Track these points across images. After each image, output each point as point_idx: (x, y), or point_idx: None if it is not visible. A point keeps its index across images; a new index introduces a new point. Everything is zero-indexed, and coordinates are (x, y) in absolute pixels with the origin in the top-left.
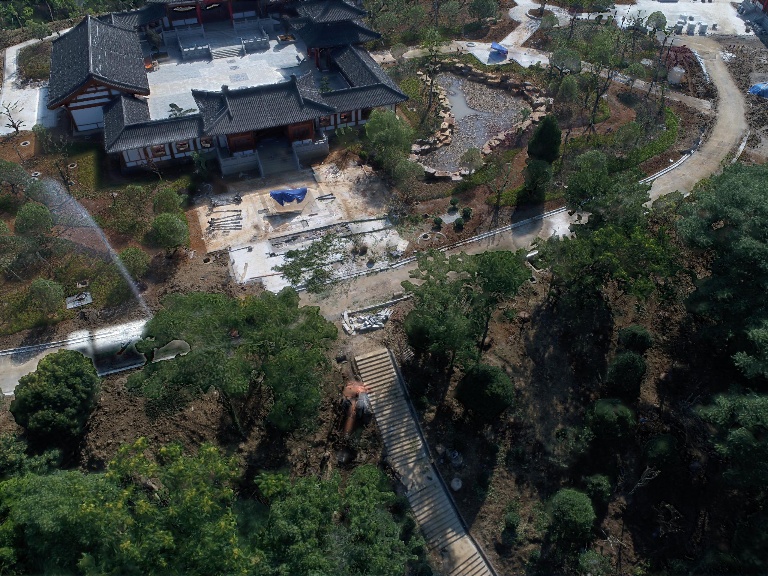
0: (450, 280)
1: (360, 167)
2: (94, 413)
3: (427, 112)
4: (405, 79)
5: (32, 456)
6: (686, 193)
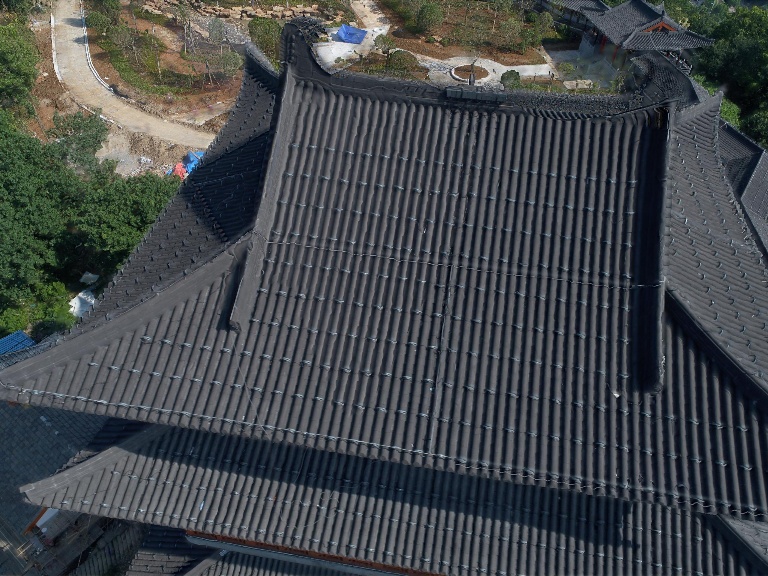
0: (54, 1)
1: None
2: None
3: (245, 5)
4: (305, 1)
5: None
6: (62, 76)
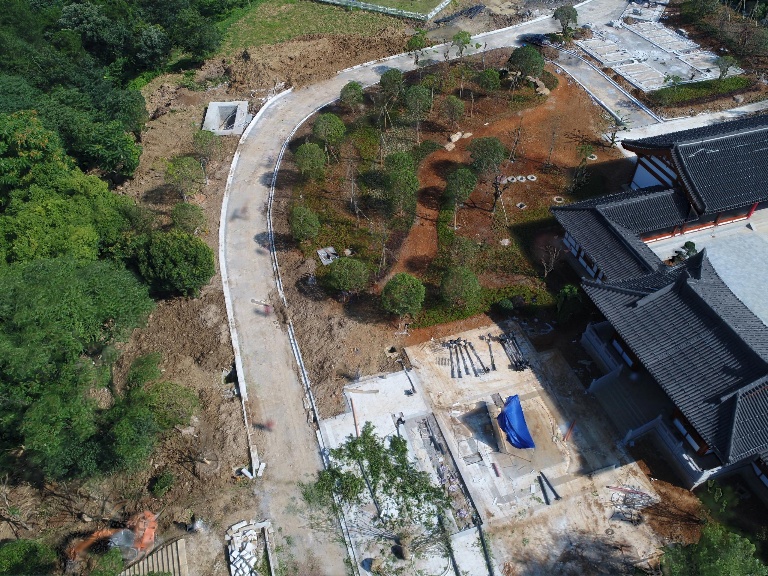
0: None
1: (662, 551)
2: (183, 298)
3: None
4: None
5: (130, 265)
6: None
